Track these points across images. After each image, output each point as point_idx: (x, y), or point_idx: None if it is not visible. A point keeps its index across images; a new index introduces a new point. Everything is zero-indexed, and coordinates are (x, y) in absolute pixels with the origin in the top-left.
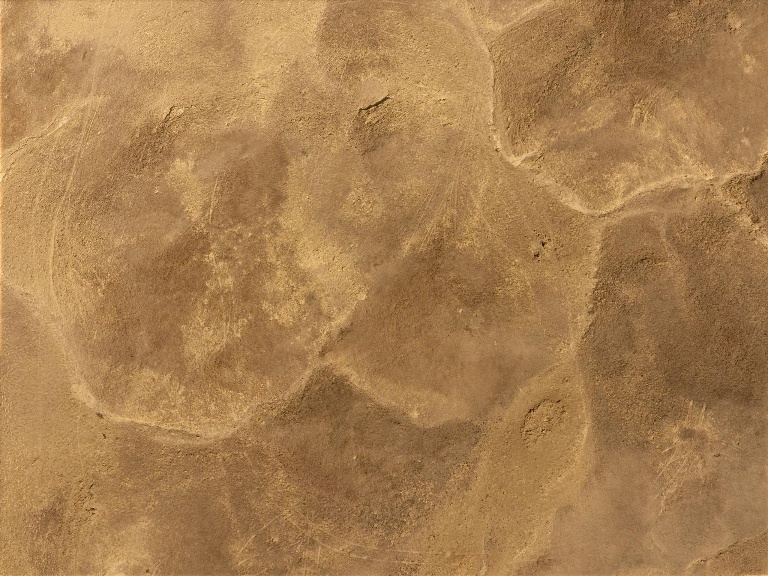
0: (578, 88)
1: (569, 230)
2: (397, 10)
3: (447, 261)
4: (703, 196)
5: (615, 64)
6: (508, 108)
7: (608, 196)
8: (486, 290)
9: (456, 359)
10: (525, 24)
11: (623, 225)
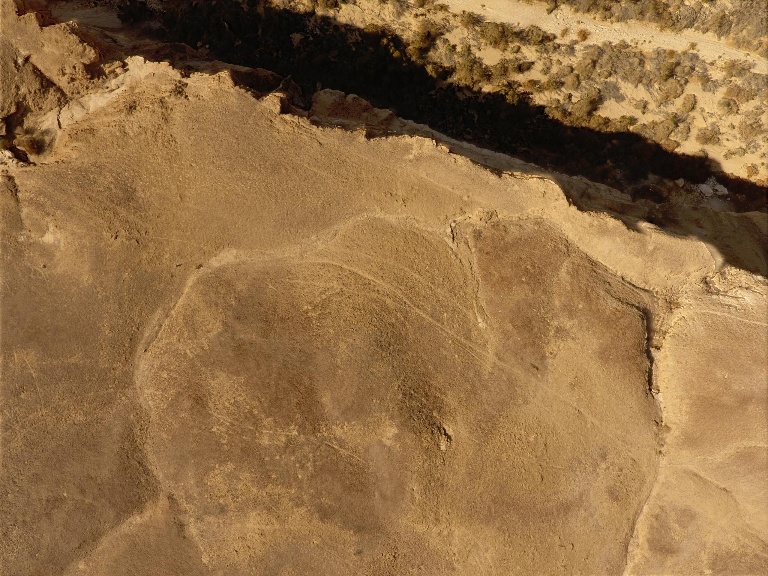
0: None
1: None
2: None
3: None
4: None
5: None
6: None
7: None
8: None
9: None
10: None
11: None
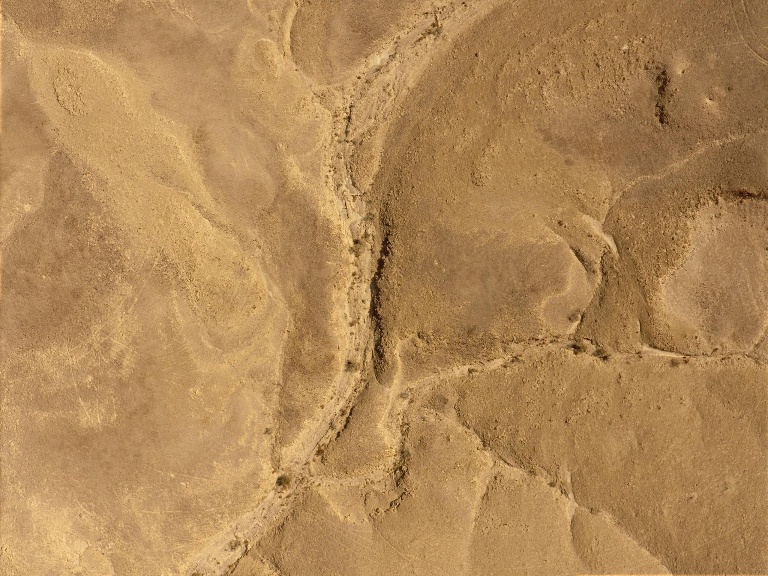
0: None
1: None
2: None
3: None
4: None
5: None
6: None
7: None
8: None
9: None
10: None
11: None
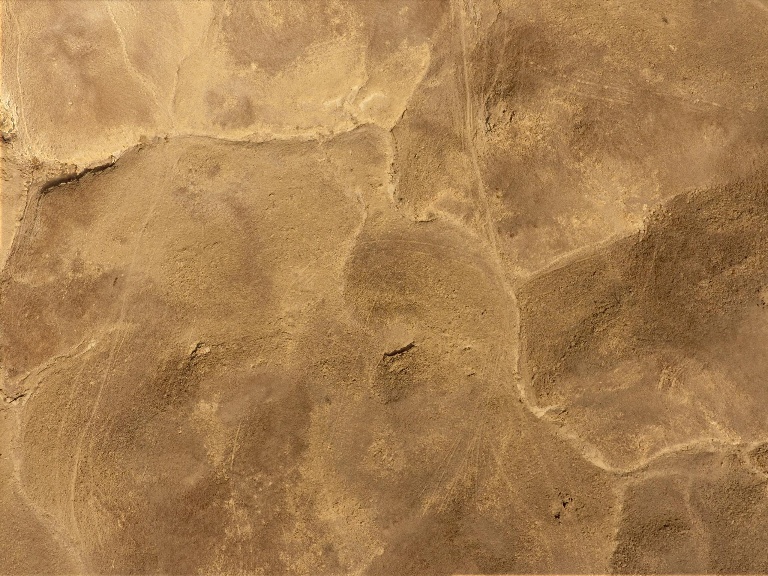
0: (605, 348)
1: (591, 489)
2: (425, 252)
3: (466, 524)
4: (729, 462)
5: (644, 327)
6: (533, 359)
7: (632, 456)
8: (505, 557)
9: None
10: (553, 273)
11: (646, 486)
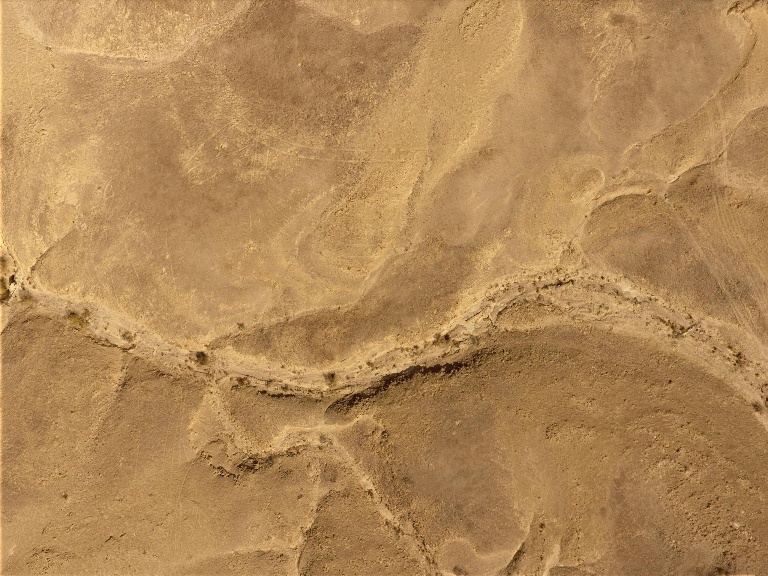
0: None
1: None
2: None
3: None
4: None
5: None
6: None
7: None
8: None
9: None
10: None
11: None
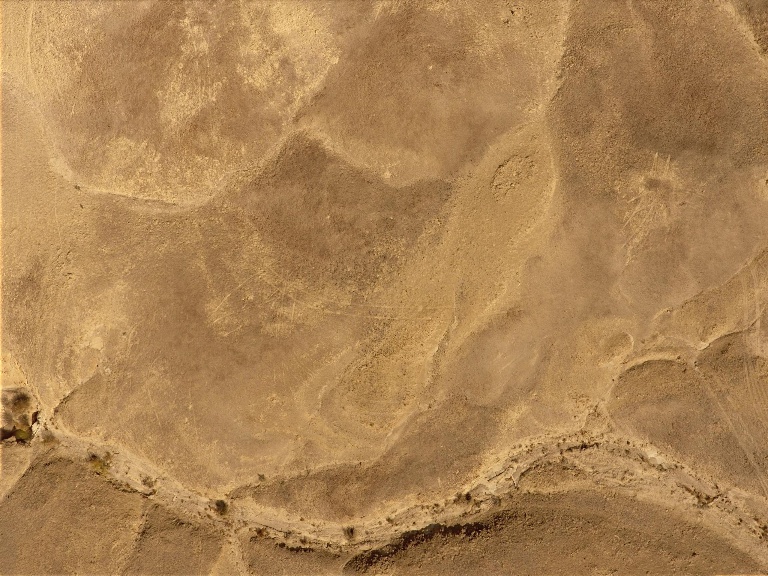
0: None
1: (538, 0)
2: None
3: (418, 22)
4: None
5: None
6: None
7: None
8: (456, 49)
9: (427, 115)
10: None
11: None
